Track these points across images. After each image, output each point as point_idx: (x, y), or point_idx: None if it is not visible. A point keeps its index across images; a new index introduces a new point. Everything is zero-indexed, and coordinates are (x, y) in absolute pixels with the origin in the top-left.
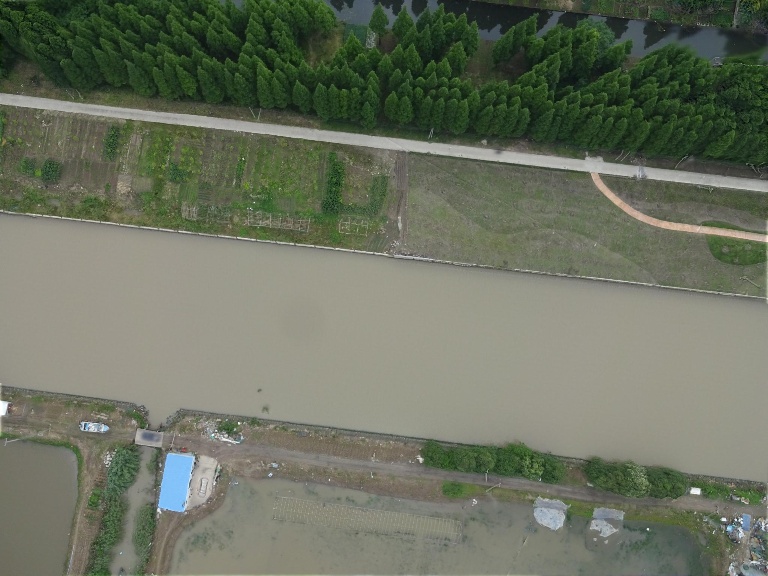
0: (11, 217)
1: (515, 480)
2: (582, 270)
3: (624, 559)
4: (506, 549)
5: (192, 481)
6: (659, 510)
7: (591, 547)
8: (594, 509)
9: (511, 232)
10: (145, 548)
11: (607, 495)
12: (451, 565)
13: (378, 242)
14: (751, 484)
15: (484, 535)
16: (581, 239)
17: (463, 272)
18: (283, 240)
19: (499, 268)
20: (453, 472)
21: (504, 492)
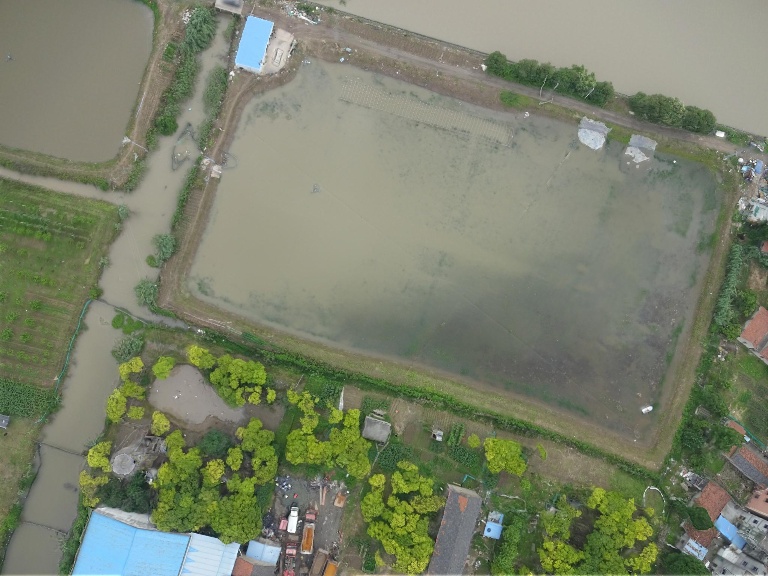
0: None
1: (566, 99)
2: None
3: (651, 184)
4: (550, 159)
5: (268, 49)
6: (687, 145)
7: (624, 169)
8: (631, 136)
9: None
10: (216, 103)
11: (645, 125)
12: (499, 166)
13: None
14: (766, 139)
15: (532, 145)
16: None
17: None
18: None
19: None
20: (512, 83)
21: (555, 108)
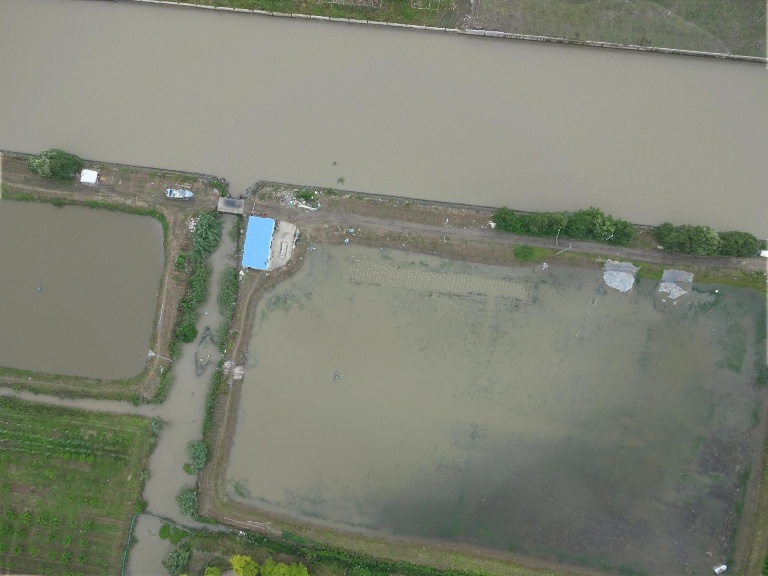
0: (92, 2)
1: (585, 244)
2: (655, 41)
3: (692, 319)
4: (576, 310)
5: (273, 244)
6: (729, 272)
7: (660, 308)
8: (663, 271)
9: (584, 1)
10: (230, 306)
11: (677, 258)
12: (522, 324)
13: (449, 18)
14: None
15: (554, 297)
16: (655, 8)
17: (534, 47)
18: (356, 17)
19: (570, 41)
20: (524, 236)
21: (574, 255)
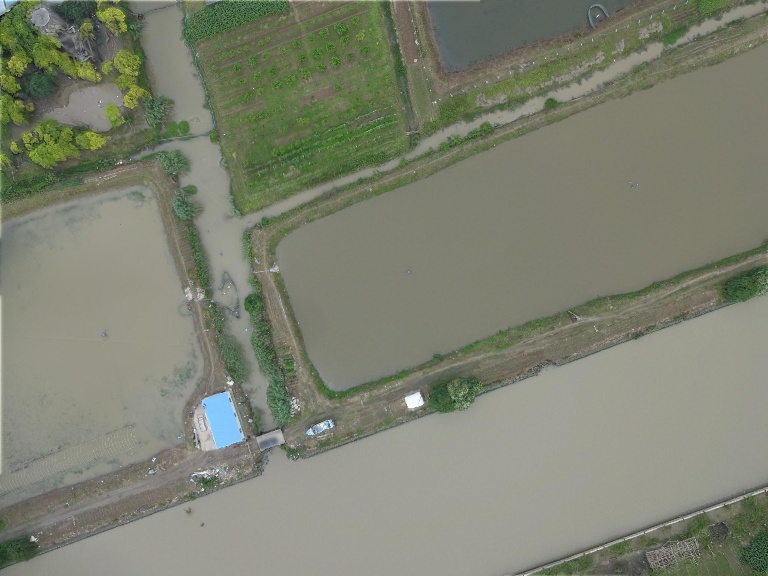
0: (516, 571)
1: None
2: None
3: None
4: None
5: None
6: None
7: None
8: None
9: None
10: (224, 349)
11: None
12: None
13: None
14: None
15: None
16: None
17: None
18: None
19: None
20: (2, 542)
21: None
